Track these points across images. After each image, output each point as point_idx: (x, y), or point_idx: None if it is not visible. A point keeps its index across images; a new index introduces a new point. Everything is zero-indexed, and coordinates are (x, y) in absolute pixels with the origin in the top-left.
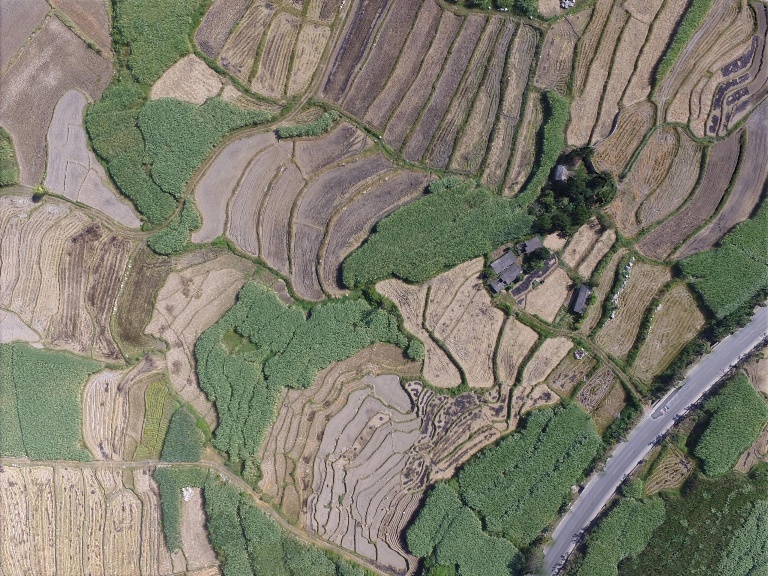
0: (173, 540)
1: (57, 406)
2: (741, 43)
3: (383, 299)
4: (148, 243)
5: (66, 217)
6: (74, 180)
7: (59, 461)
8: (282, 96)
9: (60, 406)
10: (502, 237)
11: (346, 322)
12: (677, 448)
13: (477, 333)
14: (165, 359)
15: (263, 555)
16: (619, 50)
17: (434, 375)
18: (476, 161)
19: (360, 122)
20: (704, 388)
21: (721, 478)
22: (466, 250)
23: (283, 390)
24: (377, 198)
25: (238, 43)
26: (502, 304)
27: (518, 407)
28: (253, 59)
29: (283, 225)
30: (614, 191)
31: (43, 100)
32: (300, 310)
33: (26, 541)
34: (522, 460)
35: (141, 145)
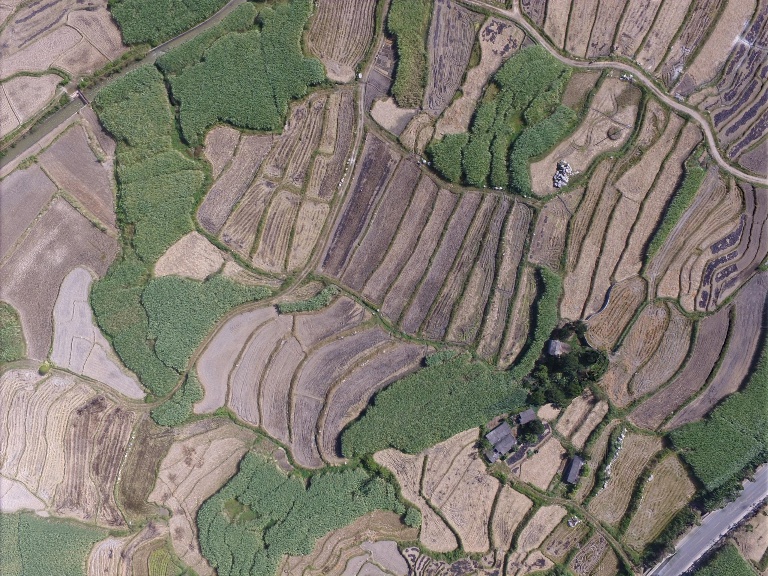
0: None
1: (62, 574)
2: (730, 221)
3: (381, 469)
4: (151, 416)
5: (71, 390)
6: (79, 354)
7: None
8: (282, 270)
9: (65, 574)
10: (497, 410)
11: (345, 491)
12: None
13: (473, 500)
14: (168, 526)
15: None
16: (611, 228)
17: (431, 540)
18: (472, 332)
19: (358, 296)
20: (695, 557)
21: None
22: (462, 423)
23: (283, 557)
24: (375, 370)
25: (239, 220)
26: (497, 473)
27: (513, 573)
28: (254, 235)
29: (283, 396)
30: (606, 364)
31: (49, 277)
32: (300, 480)
33: None
34: None
35: (145, 321)
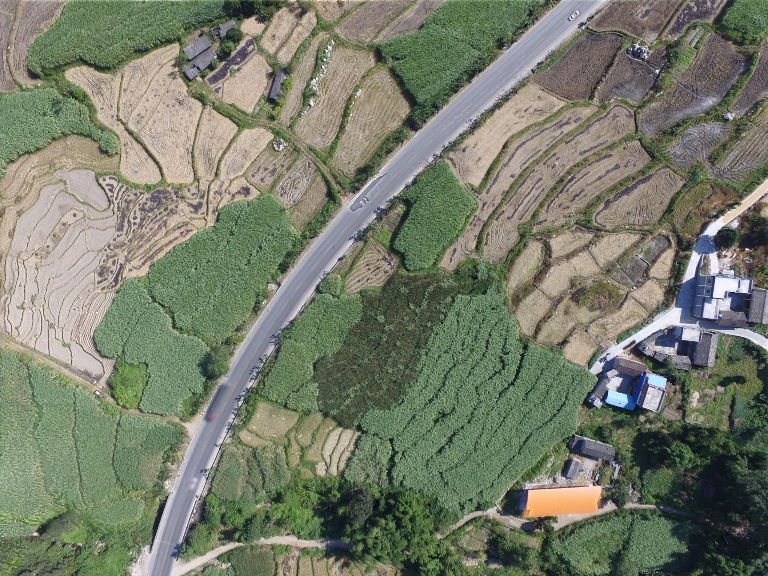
0: None
1: None
2: None
3: (72, 87)
4: None
5: None
6: None
7: None
8: None
9: None
10: (192, 18)
11: (34, 111)
12: (379, 243)
13: (174, 125)
14: None
15: None
16: None
17: (132, 171)
18: None
19: None
20: (407, 179)
21: (422, 273)
22: (154, 32)
23: None
24: None
25: None
26: (197, 92)
27: (216, 202)
28: None
29: None
30: None
31: None
32: None
33: None
34: (214, 254)
35: None
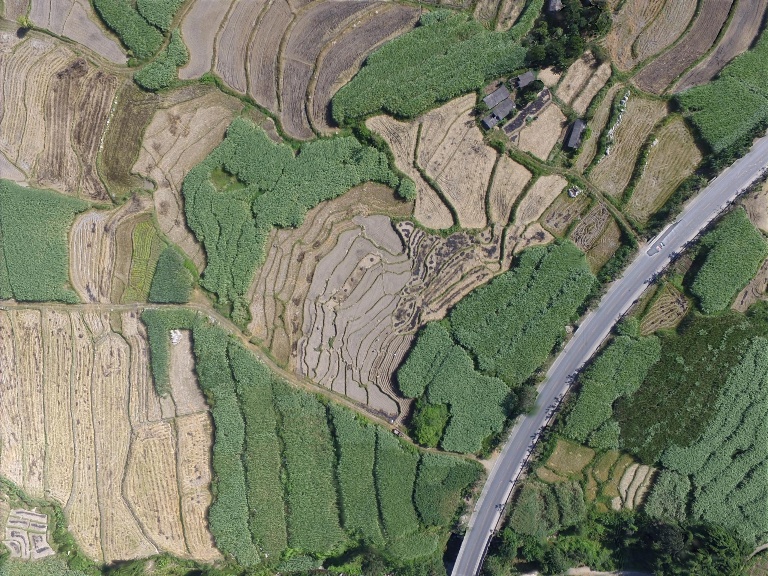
0: (161, 383)
1: (43, 245)
2: None
3: (373, 135)
4: (134, 77)
5: (51, 52)
6: (59, 14)
7: (46, 304)
8: None
9: (46, 245)
10: (495, 69)
11: (336, 159)
12: (673, 286)
13: (469, 172)
14: (152, 199)
15: (252, 397)
16: None
17: (426, 216)
18: None
19: None
20: (701, 225)
21: (718, 315)
22: (458, 83)
23: (272, 229)
24: (367, 33)
25: None
26: (495, 141)
27: (511, 247)
28: None
29: (271, 61)
30: (609, 24)
31: None
32: (289, 147)
33: (14, 387)
34: (515, 298)
35: None
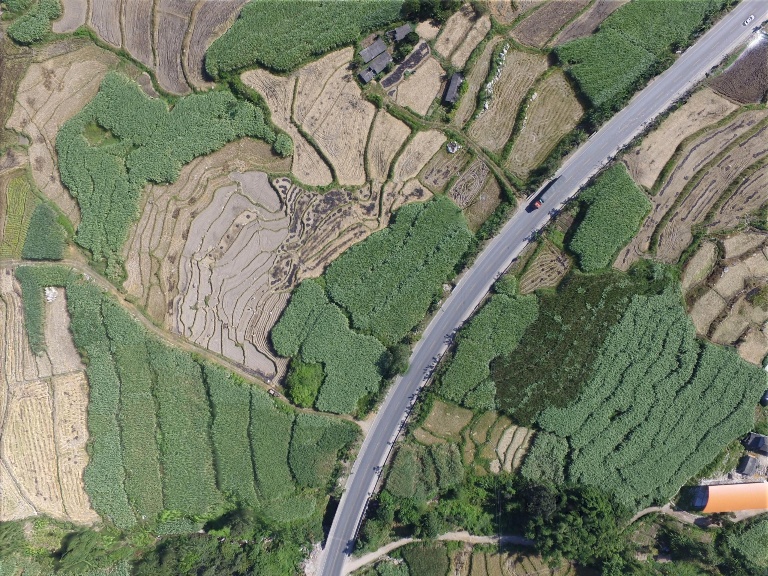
0: (36, 340)
1: None
2: None
3: (248, 89)
4: (7, 31)
5: None
6: None
7: None
8: None
9: None
10: (370, 22)
11: (210, 114)
12: (553, 244)
13: (347, 127)
14: (27, 154)
15: (127, 356)
16: None
17: (304, 173)
18: None
19: None
20: (581, 181)
21: (598, 273)
22: (332, 35)
23: (146, 185)
24: None
25: None
26: (372, 95)
27: (389, 204)
28: None
29: (146, 15)
30: None
31: None
32: (163, 101)
33: None
34: (391, 255)
35: None
